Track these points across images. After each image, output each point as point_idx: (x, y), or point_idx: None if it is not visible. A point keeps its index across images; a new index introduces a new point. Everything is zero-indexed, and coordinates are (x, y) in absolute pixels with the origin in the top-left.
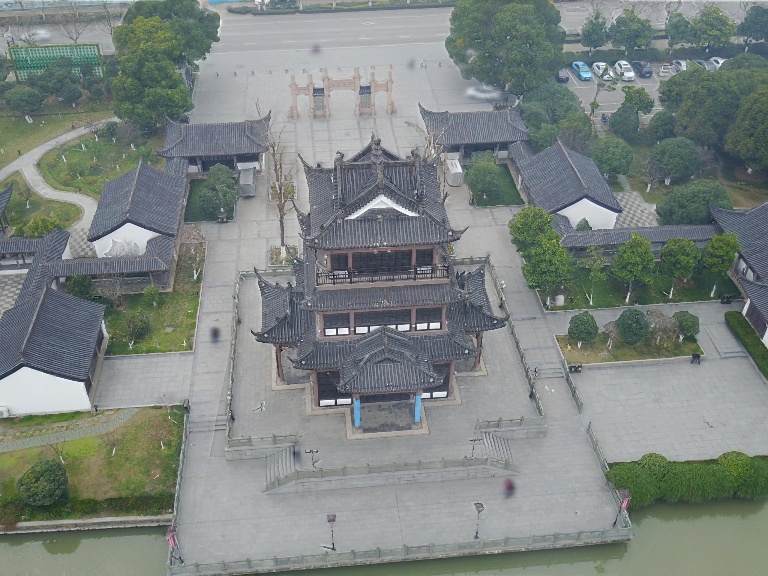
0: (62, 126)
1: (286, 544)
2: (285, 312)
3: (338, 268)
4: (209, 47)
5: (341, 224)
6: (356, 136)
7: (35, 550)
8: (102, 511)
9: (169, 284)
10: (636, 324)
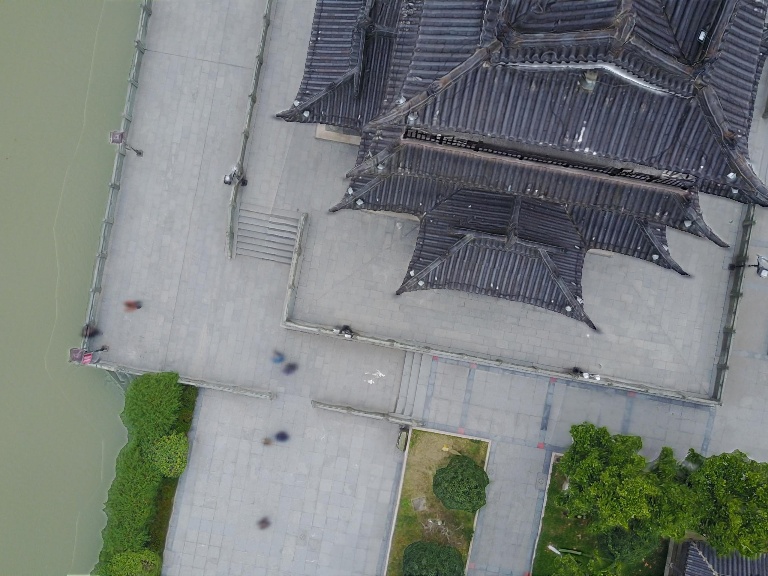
0: None
1: None
2: None
3: None
4: None
5: None
6: None
7: None
8: None
9: None
10: (419, 571)
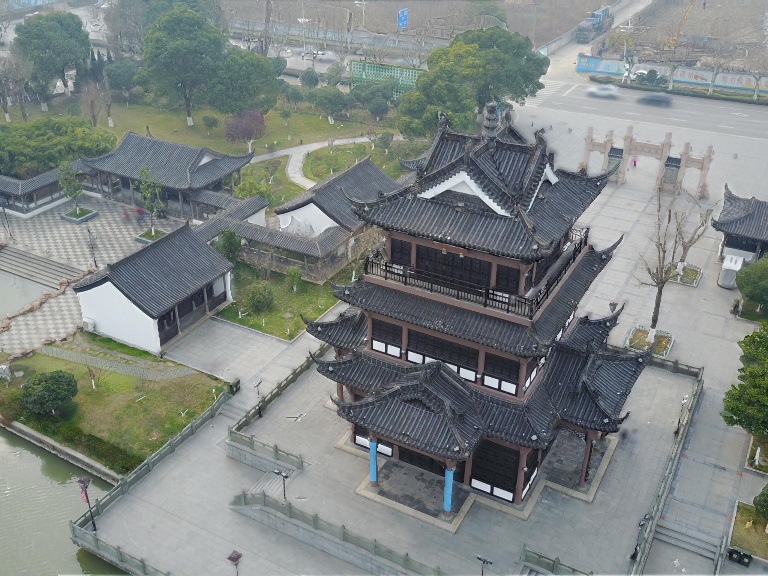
0: (354, 132)
1: (201, 570)
2: (355, 312)
3: (399, 261)
4: (520, 86)
5: (410, 201)
6: (638, 208)
7: (33, 462)
8: (81, 445)
9: (323, 277)
10: None
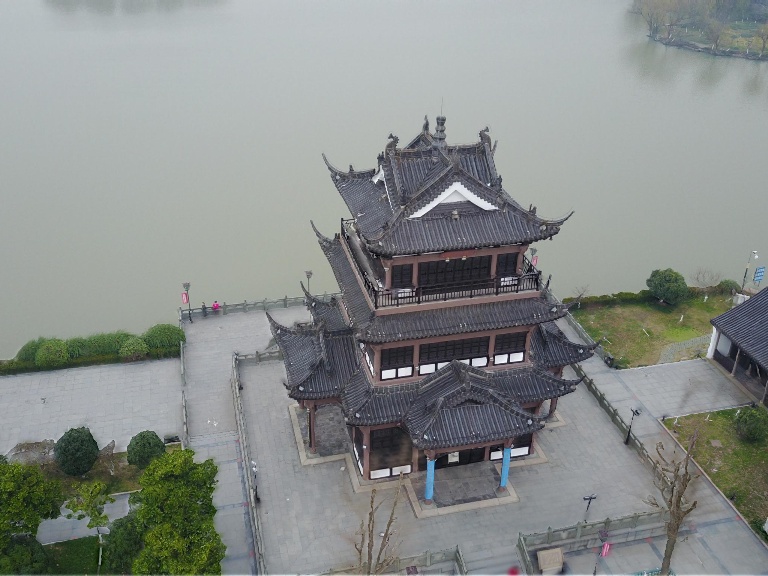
0: None
1: None
2: None
3: None
4: None
5: None
6: None
7: None
8: None
9: None
10: None
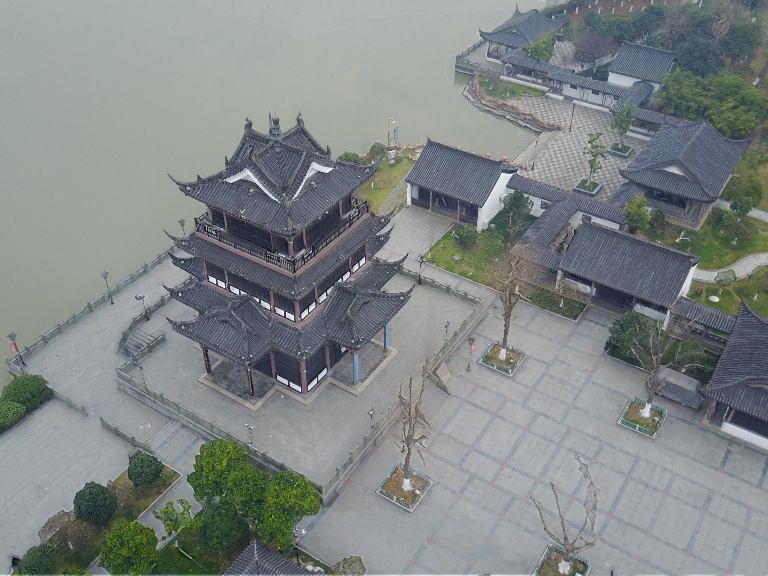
0: None
1: None
2: None
3: None
4: None
5: None
6: None
7: None
8: None
9: None
10: None
